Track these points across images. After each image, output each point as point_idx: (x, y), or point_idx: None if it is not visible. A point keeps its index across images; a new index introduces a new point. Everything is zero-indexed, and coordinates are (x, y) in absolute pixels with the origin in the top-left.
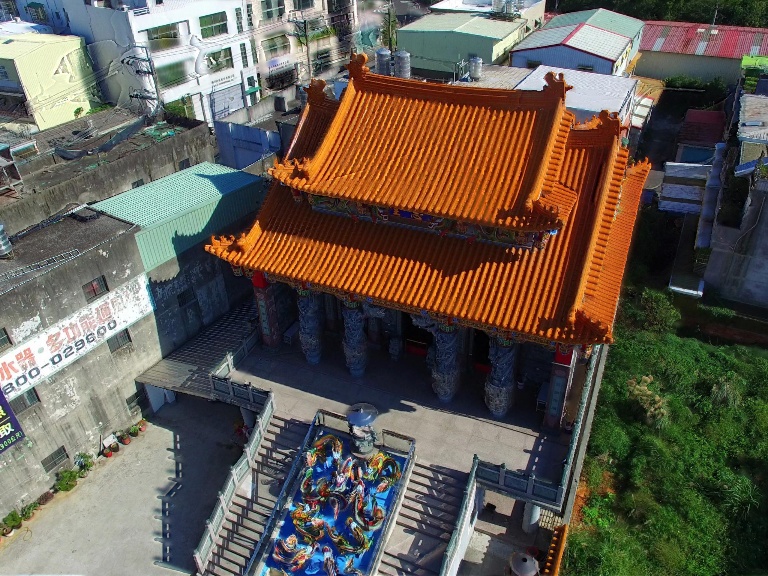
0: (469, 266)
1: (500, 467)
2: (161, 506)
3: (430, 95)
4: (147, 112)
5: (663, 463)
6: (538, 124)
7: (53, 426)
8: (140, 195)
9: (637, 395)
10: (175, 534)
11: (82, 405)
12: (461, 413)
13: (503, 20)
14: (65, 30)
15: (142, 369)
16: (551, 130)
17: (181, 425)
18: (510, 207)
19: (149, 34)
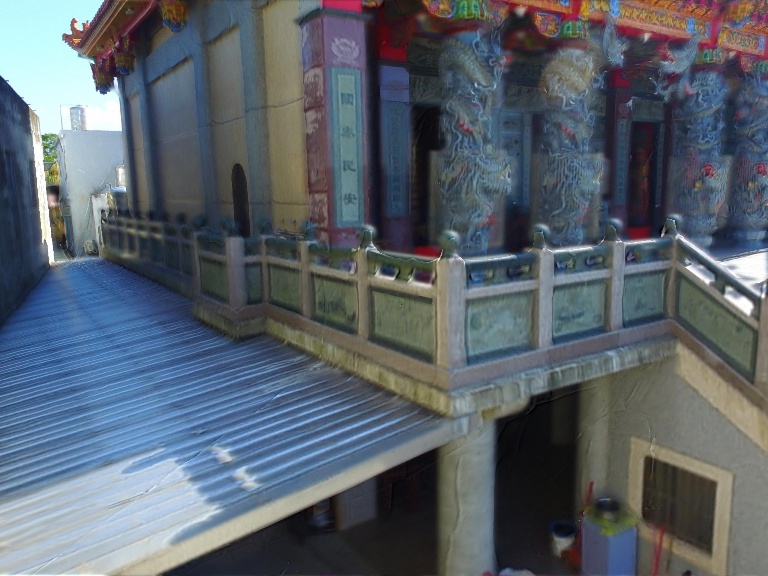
0: None
1: None
2: None
3: None
4: None
5: None
6: None
7: None
8: None
9: None
10: None
11: None
12: (743, 252)
13: None
14: None
15: None
16: None
17: None
18: None
19: None
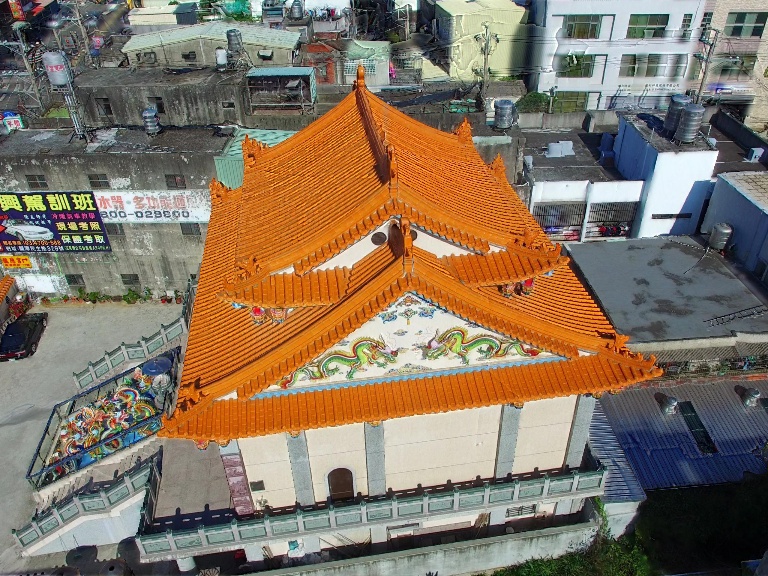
0: None
1: None
2: None
3: None
4: None
5: None
6: None
7: (132, 257)
8: (277, 136)
9: None
10: None
11: (155, 256)
12: None
13: None
14: None
15: None
16: (352, 210)
17: None
18: None
19: (565, 20)
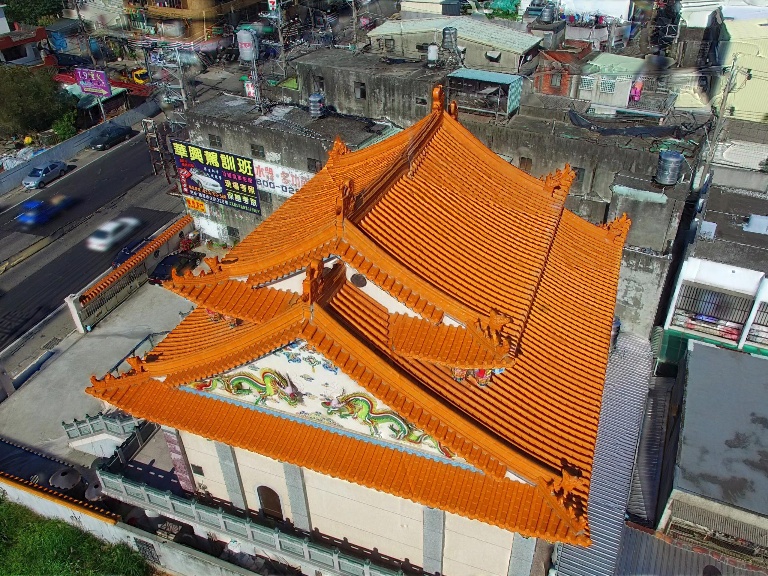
0: None
1: None
2: None
3: None
4: None
5: None
6: None
7: None
8: None
9: None
10: None
11: None
12: None
13: None
14: None
15: None
16: None
17: None
18: None
19: None
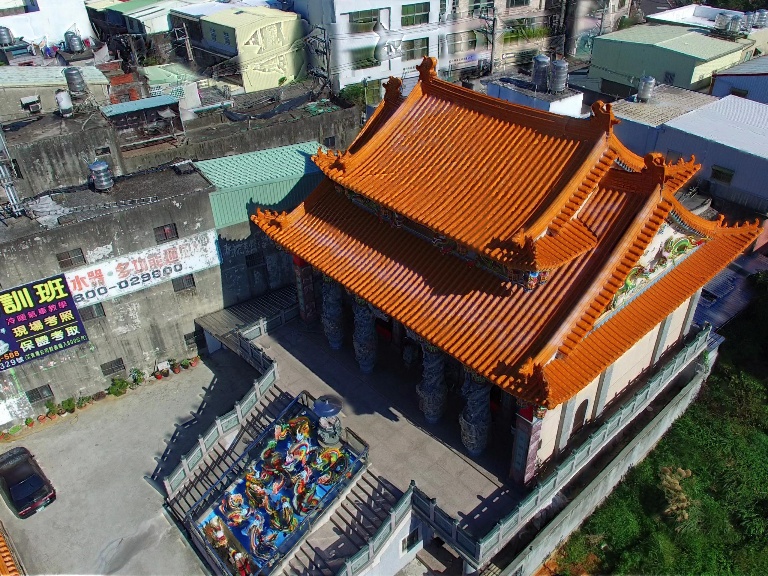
0: (460, 290)
1: (430, 501)
2: (173, 433)
3: (485, 108)
4: (336, 89)
5: (656, 569)
6: (576, 156)
7: (114, 339)
8: (239, 161)
9: (664, 486)
10: (171, 459)
11: (142, 329)
12: (438, 438)
13: (723, 38)
14: (291, 7)
15: (203, 313)
16: (581, 165)
17: (223, 371)
18: (506, 238)
19: (351, 17)
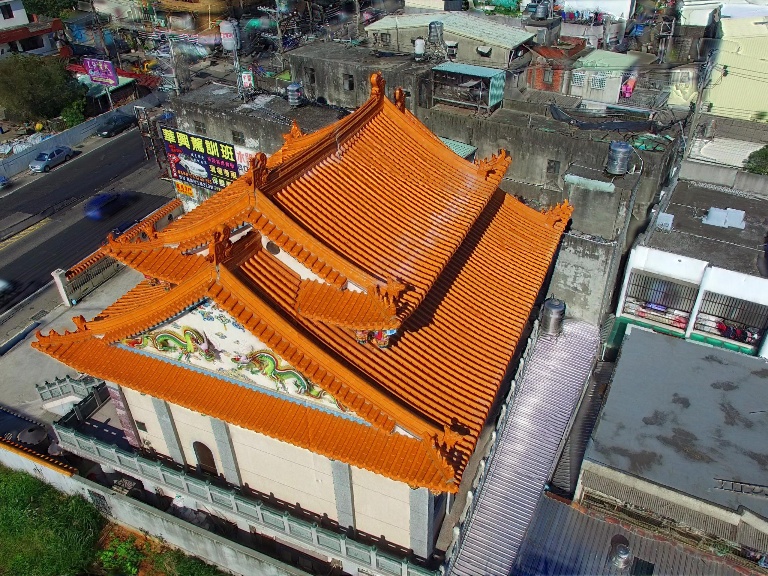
0: None
1: None
2: None
3: None
4: None
5: None
6: None
7: None
8: None
9: None
10: None
11: None
12: None
13: None
14: None
15: None
16: None
17: None
18: None
19: None
